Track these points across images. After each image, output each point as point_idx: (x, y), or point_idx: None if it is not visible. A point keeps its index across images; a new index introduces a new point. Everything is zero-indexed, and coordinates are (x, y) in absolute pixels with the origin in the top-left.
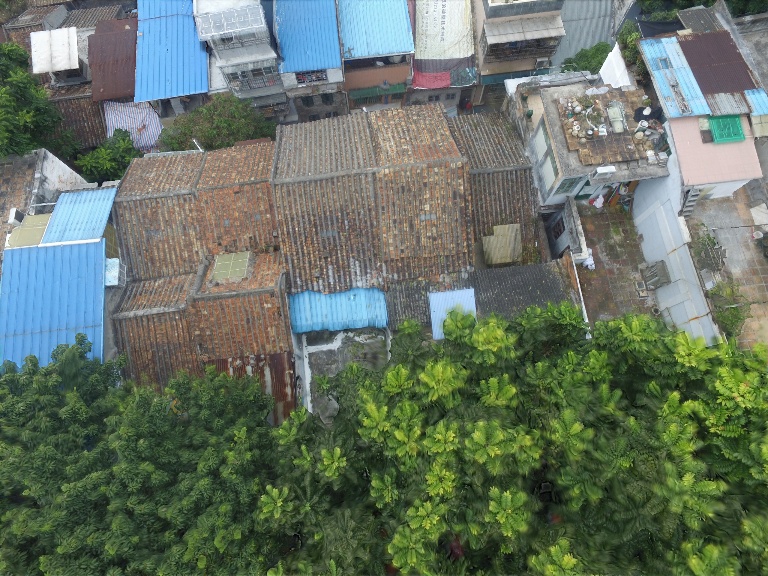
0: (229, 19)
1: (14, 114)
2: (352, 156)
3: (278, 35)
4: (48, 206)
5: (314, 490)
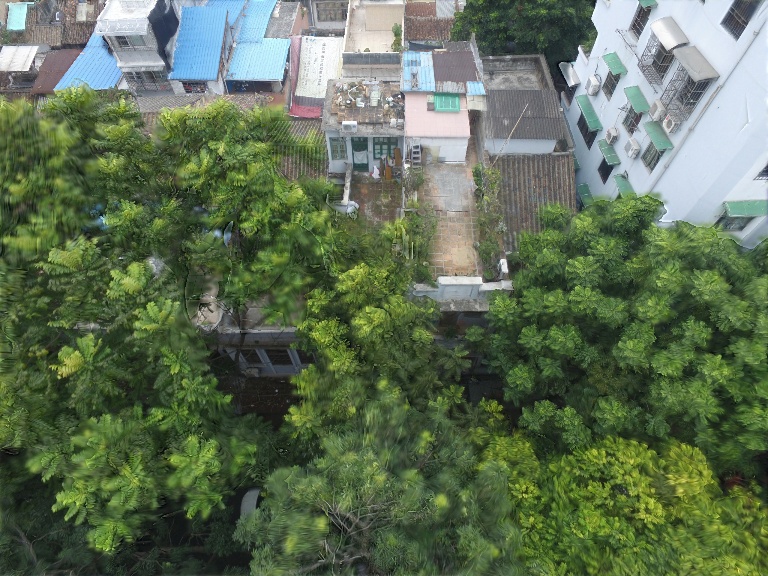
0: (123, 26)
1: None
2: None
3: (174, 54)
4: None
5: None
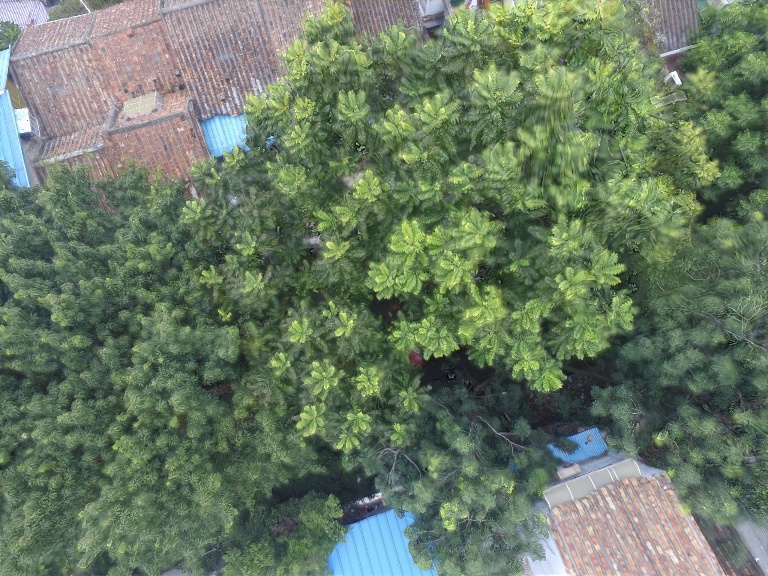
0: None
1: None
2: None
3: None
4: None
5: None
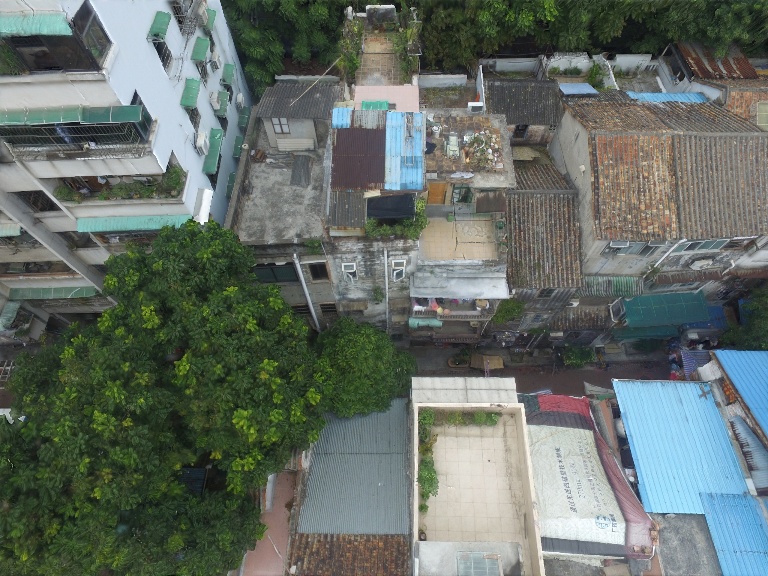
0: None
1: None
2: (696, 160)
3: None
4: None
5: None
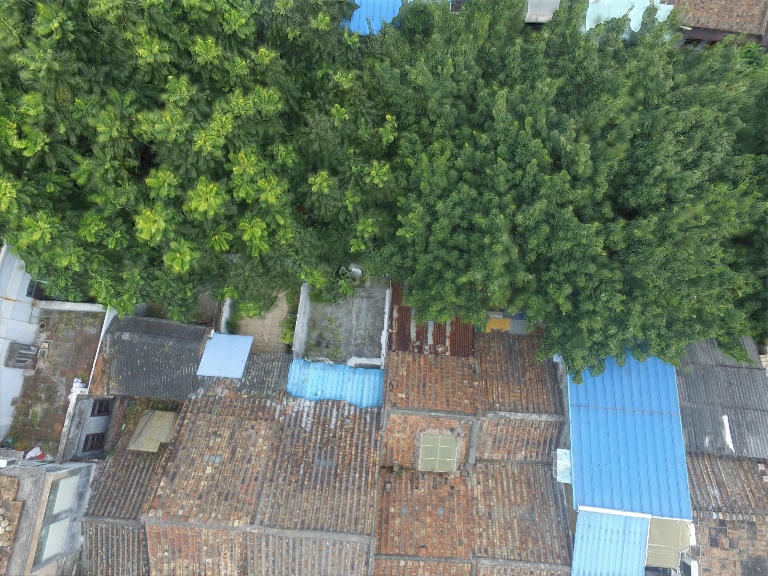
0: None
1: None
2: (274, 561)
3: None
4: None
5: None
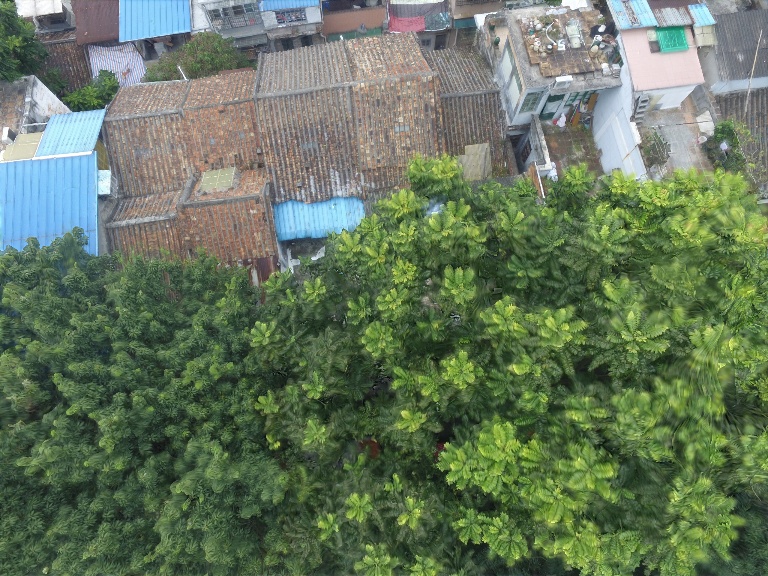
0: None
1: (4, 38)
2: (330, 74)
3: None
4: (39, 130)
5: (298, 329)
